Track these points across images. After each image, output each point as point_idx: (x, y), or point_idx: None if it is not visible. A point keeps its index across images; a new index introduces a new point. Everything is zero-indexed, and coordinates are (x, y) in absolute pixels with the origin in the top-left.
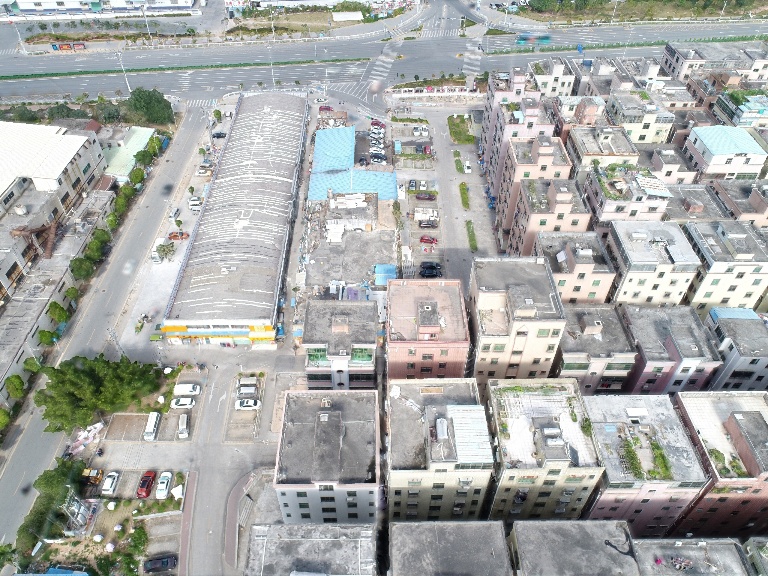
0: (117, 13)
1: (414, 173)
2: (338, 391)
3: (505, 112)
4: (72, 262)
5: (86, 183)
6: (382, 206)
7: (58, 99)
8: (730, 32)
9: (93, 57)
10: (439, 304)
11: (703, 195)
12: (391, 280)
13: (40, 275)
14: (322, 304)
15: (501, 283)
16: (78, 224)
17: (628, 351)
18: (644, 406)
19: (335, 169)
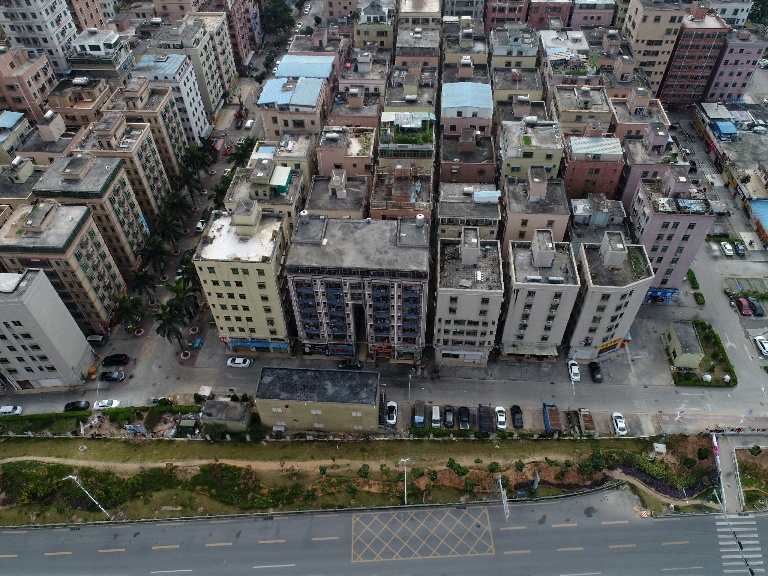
0: None
1: (745, 270)
2: (729, 3)
3: (679, 161)
4: None
5: None
6: (761, 192)
7: None
8: None
9: None
10: (694, 25)
11: (501, 86)
12: (728, 28)
13: None
14: (761, 45)
15: (667, 6)
16: None
17: (582, 30)
18: (588, 1)
19: None
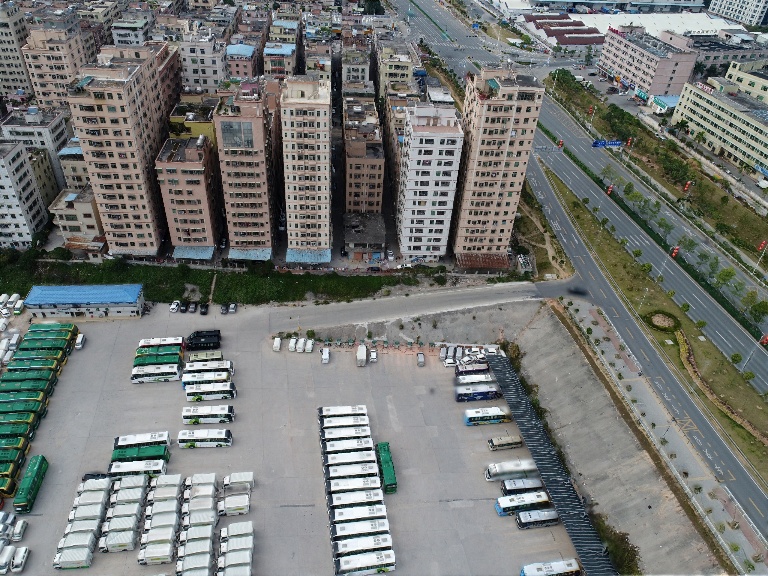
0: (484, 6)
1: None
2: None
3: None
4: (275, 2)
5: (317, 1)
6: None
7: (394, 5)
8: (567, 135)
9: (436, 7)
10: None
11: None
12: None
13: (271, 1)
14: None
15: None
16: (293, 1)
17: None
18: None
19: (332, 28)
